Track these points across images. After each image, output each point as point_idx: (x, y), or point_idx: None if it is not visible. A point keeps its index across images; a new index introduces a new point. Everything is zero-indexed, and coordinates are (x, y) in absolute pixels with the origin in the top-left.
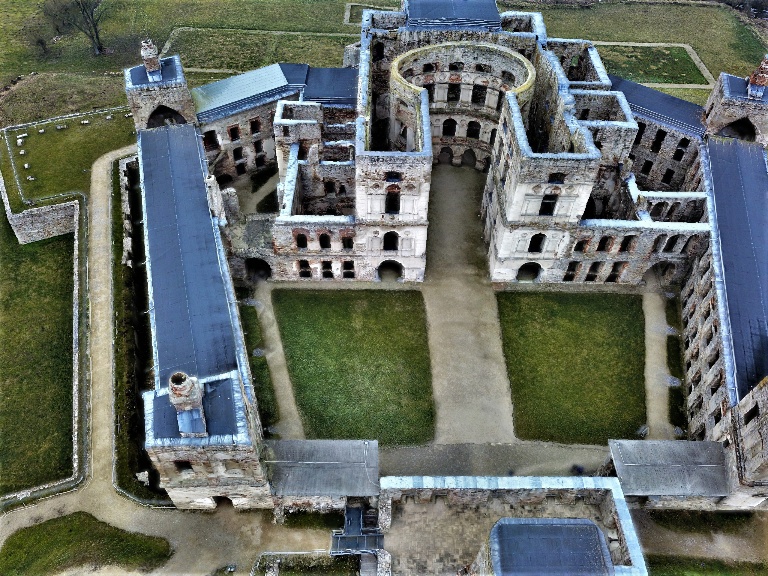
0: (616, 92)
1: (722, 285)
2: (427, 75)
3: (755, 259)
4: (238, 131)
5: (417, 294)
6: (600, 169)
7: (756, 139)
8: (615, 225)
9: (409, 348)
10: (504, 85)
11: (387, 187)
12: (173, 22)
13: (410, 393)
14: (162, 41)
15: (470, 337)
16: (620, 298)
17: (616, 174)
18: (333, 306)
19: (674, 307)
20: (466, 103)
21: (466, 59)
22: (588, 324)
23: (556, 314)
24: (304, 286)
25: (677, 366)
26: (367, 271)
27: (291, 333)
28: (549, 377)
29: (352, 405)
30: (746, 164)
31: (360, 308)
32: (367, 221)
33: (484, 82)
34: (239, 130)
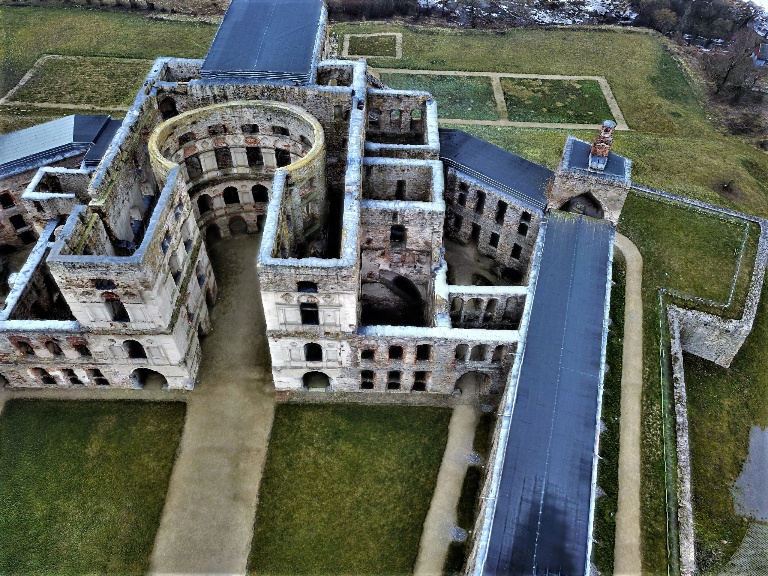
0: (433, 161)
1: (508, 422)
2: (216, 138)
3: (557, 386)
4: (11, 197)
5: (180, 407)
6: (413, 253)
7: (604, 216)
8: (401, 334)
9: (143, 485)
10: (305, 151)
11: (101, 294)
12: (42, 49)
13: (123, 552)
14: (23, 71)
15: (224, 469)
16: (425, 413)
17: (430, 260)
18: (72, 424)
19: (487, 426)
20: (272, 168)
21: (259, 120)
22: (375, 450)
23: (340, 436)
24: (48, 395)
25: (468, 512)
26: (121, 379)
27: (6, 463)
28: (304, 528)
29: (44, 570)
30: (584, 249)
31: (104, 427)
32: (94, 329)
33: (286, 146)
34: (11, 196)
